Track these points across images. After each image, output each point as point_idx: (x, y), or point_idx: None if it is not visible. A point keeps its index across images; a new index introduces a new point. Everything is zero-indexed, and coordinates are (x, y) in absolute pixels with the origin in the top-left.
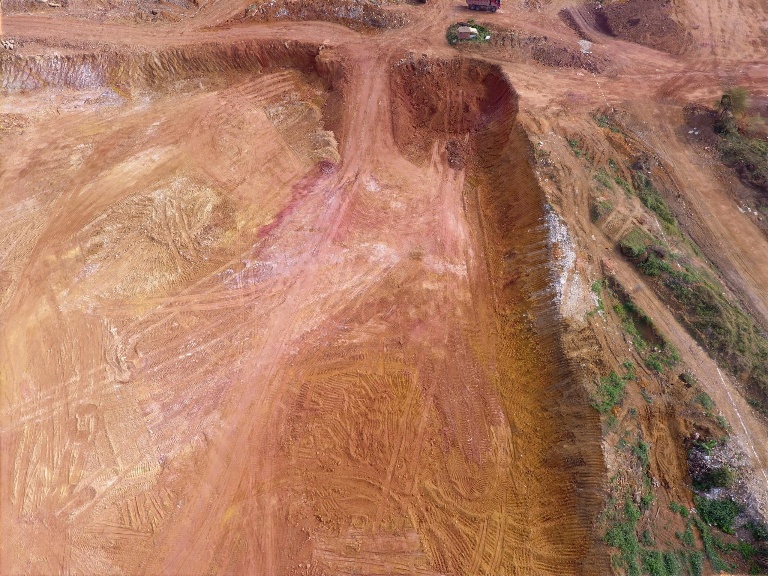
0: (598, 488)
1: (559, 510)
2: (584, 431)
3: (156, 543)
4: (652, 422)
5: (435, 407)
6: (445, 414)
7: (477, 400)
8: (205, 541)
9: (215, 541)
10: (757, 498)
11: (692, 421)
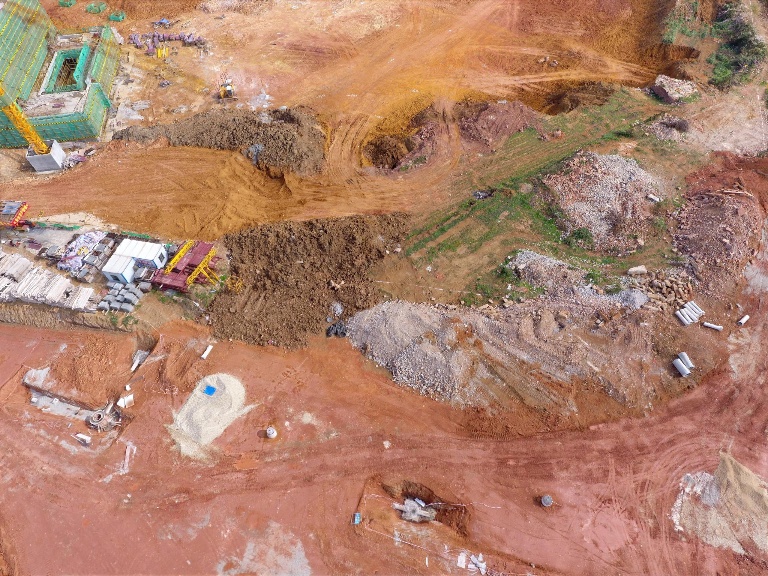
0: (669, 10)
1: (647, 24)
2: (669, 2)
3: (470, 6)
4: (705, 0)
5: (597, 2)
6: (601, 4)
7: (618, 3)
8: (489, 9)
9: (493, 10)
10: (743, 15)
11: (725, 0)
